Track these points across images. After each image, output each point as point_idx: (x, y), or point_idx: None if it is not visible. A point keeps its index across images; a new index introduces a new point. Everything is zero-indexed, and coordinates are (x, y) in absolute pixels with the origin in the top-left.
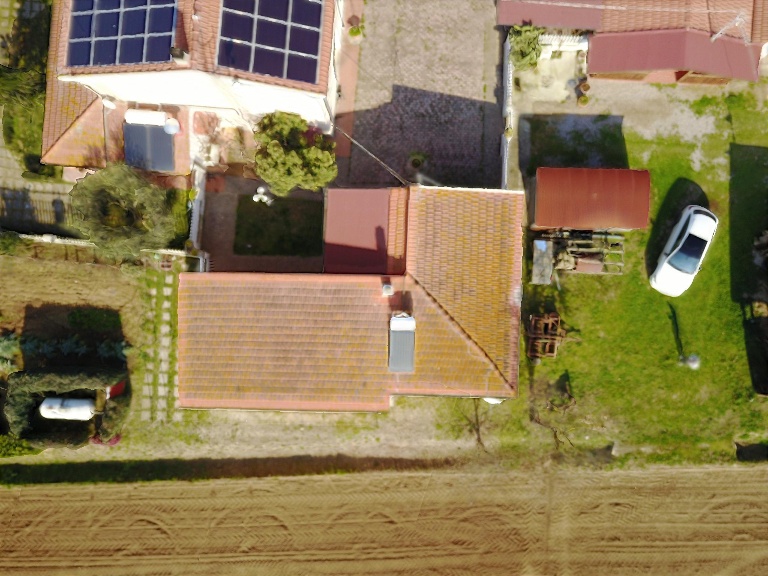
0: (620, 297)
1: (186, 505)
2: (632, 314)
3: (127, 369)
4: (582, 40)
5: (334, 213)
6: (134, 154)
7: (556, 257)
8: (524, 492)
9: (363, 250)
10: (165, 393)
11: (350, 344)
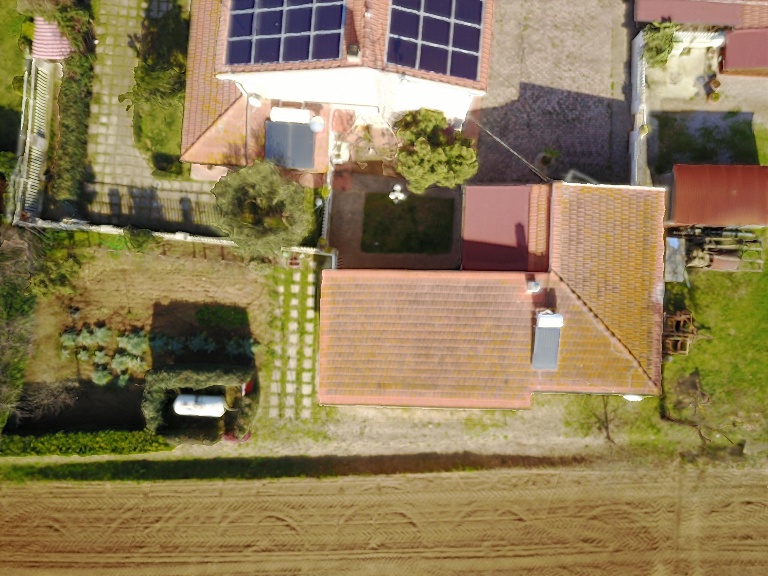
0: (751, 295)
1: (315, 502)
2: (763, 312)
3: (255, 366)
4: (716, 37)
5: (472, 210)
6: (275, 152)
7: (689, 254)
8: (653, 490)
9: (503, 247)
10: (293, 390)
11: (492, 341)
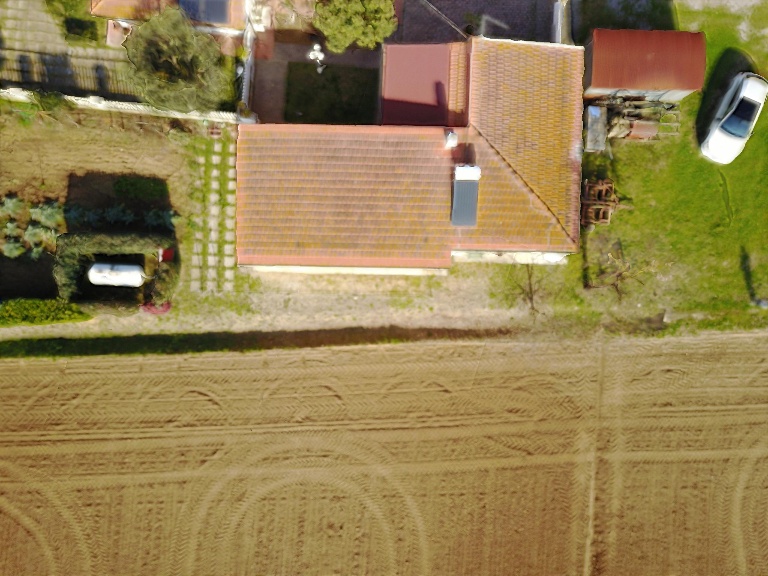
0: (672, 166)
1: (238, 376)
2: (683, 182)
3: (176, 239)
4: None
5: (393, 69)
6: (189, 5)
7: (611, 122)
8: (577, 360)
9: (423, 106)
10: (215, 263)
11: (412, 198)
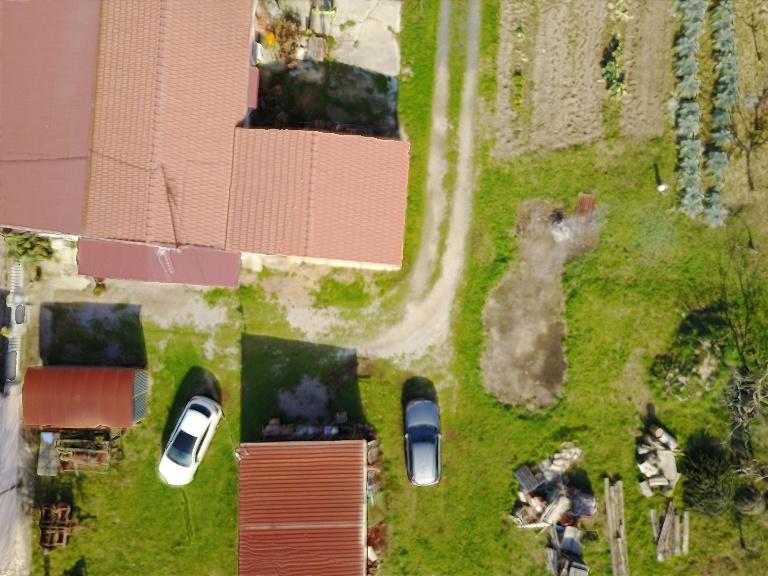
0: (136, 483)
1: None
2: (147, 500)
3: None
4: None
5: None
6: None
7: None
8: None
9: None
10: None
11: None
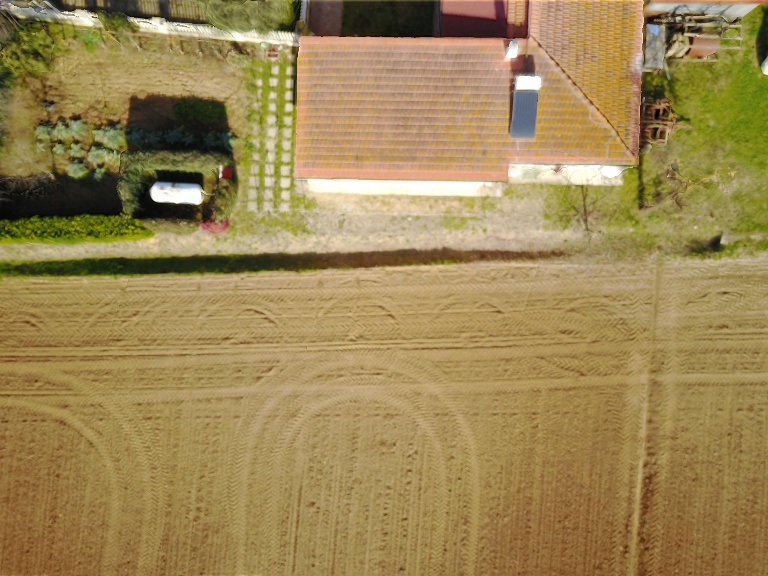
0: (730, 86)
1: (293, 295)
2: (742, 103)
3: (233, 160)
4: None
5: None
6: None
7: (669, 40)
8: (631, 283)
9: (482, 20)
10: (272, 184)
11: (470, 111)
